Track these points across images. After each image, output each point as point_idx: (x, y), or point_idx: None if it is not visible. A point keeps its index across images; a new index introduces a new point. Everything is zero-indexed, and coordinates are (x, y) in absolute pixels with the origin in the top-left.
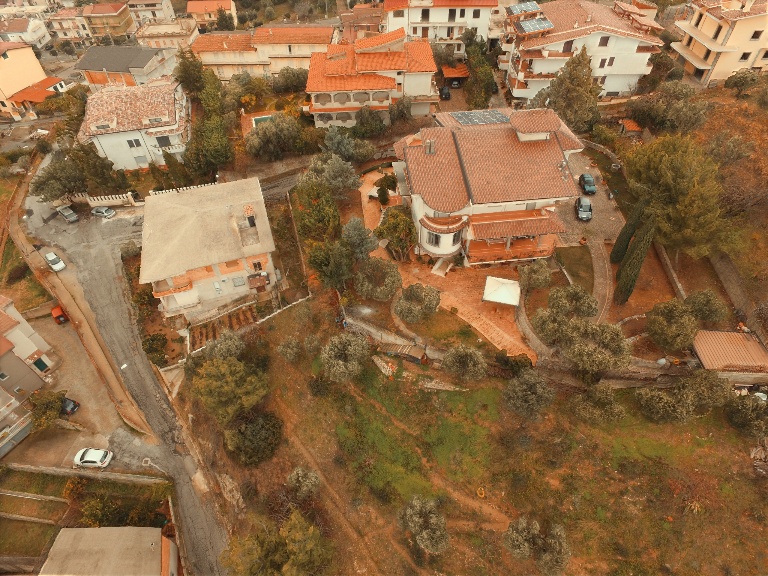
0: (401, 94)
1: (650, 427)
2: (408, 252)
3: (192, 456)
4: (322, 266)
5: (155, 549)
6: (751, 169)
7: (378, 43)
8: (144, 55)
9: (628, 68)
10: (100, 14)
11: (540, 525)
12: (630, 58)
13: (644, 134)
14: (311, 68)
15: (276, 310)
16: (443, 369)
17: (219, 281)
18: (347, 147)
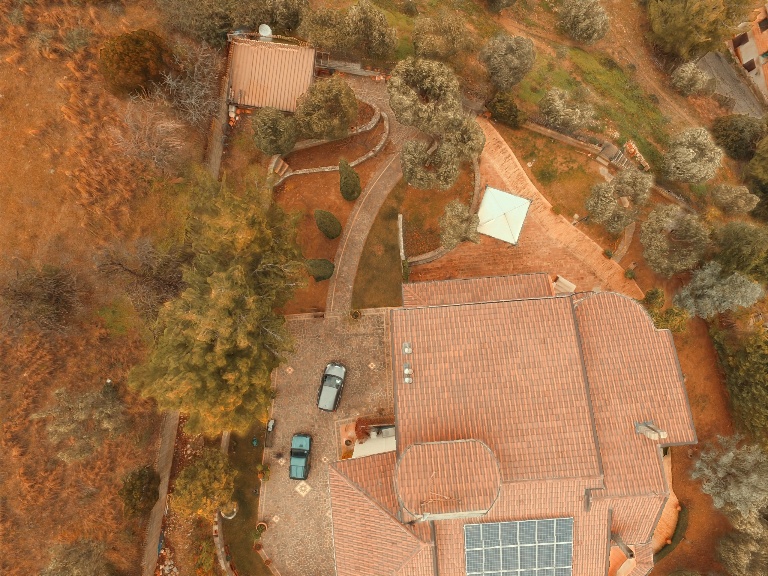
0: None
1: None
2: None
3: None
4: None
5: None
6: (39, 419)
7: None
8: None
9: None
10: None
11: None
12: None
13: None
14: None
15: None
16: None
17: None
18: None
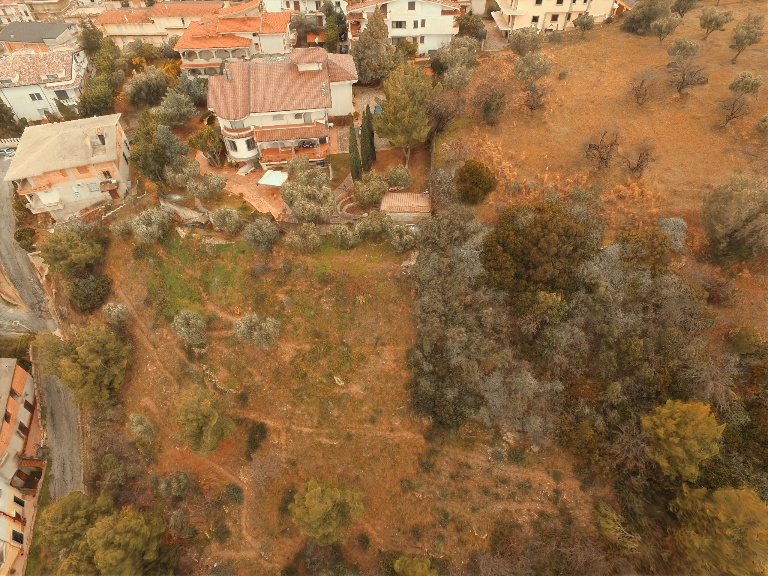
0: (260, 53)
1: (342, 252)
2: (224, 161)
3: (54, 320)
4: (137, 161)
5: (9, 370)
6: None
7: (237, 10)
8: (57, 28)
9: (439, 29)
10: (41, 1)
11: None
12: (438, 20)
13: (435, 77)
14: (185, 32)
15: (119, 206)
16: (222, 231)
17: (75, 186)
18: (195, 89)
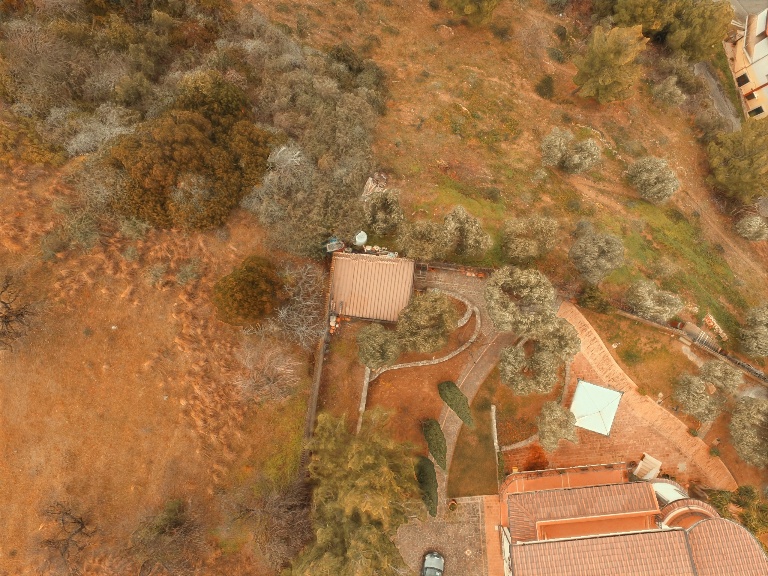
0: None
1: None
2: None
3: None
4: None
5: None
6: None
7: None
8: None
9: None
10: None
11: (555, 174)
12: None
13: None
14: None
15: None
16: None
17: None
18: None
